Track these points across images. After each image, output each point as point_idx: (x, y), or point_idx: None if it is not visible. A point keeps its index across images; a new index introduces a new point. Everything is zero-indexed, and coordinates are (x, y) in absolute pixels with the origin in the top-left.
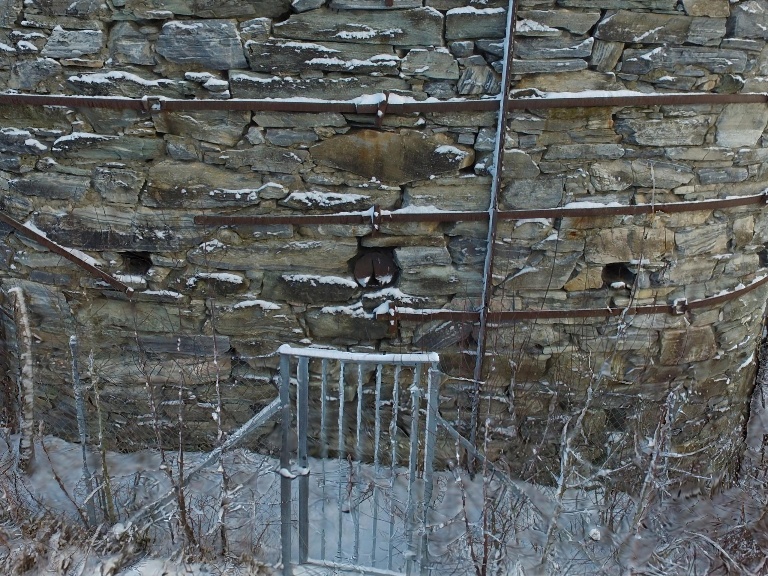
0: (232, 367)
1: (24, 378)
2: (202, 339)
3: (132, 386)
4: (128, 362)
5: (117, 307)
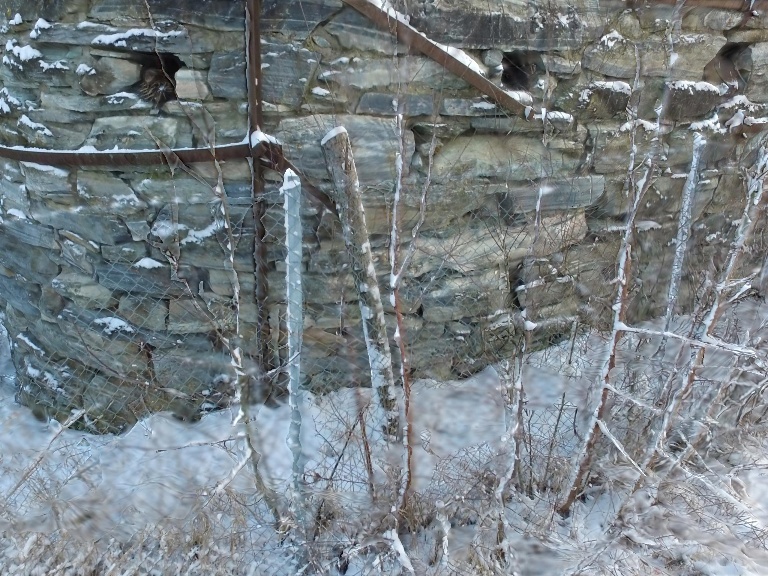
0: (585, 222)
1: (372, 285)
2: (580, 182)
3: (485, 272)
4: (482, 236)
5: (483, 147)
